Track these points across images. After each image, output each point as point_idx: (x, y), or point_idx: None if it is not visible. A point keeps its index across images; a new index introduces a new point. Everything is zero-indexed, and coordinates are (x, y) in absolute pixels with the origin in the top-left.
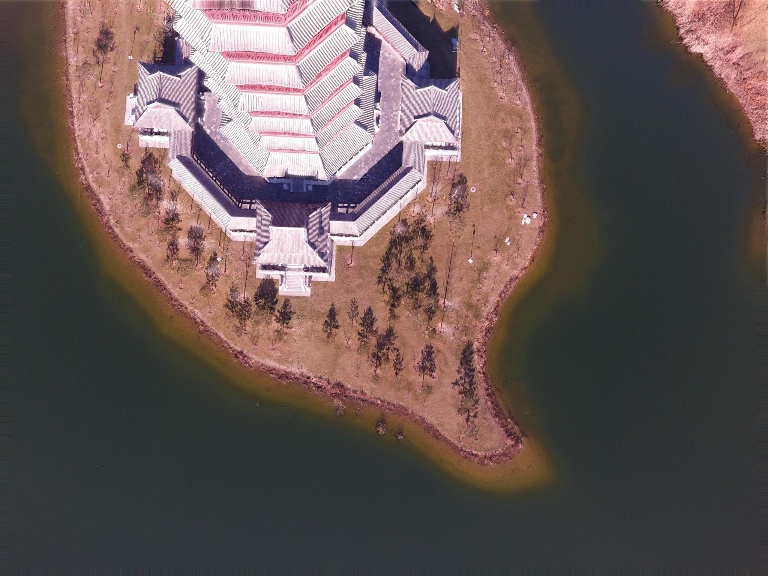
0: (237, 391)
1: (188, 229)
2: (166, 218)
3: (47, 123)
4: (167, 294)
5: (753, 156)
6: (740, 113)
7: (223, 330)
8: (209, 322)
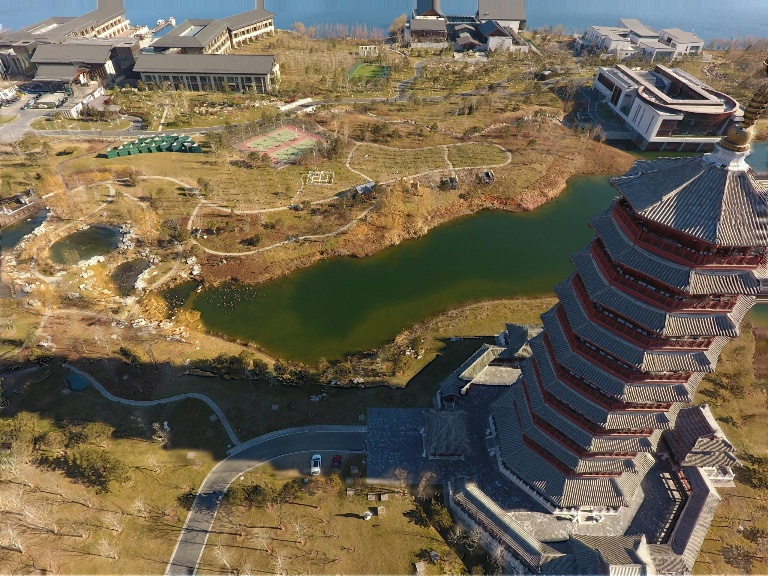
0: None
1: (730, 567)
2: None
3: None
4: None
5: (482, 215)
6: (458, 218)
7: None
8: None
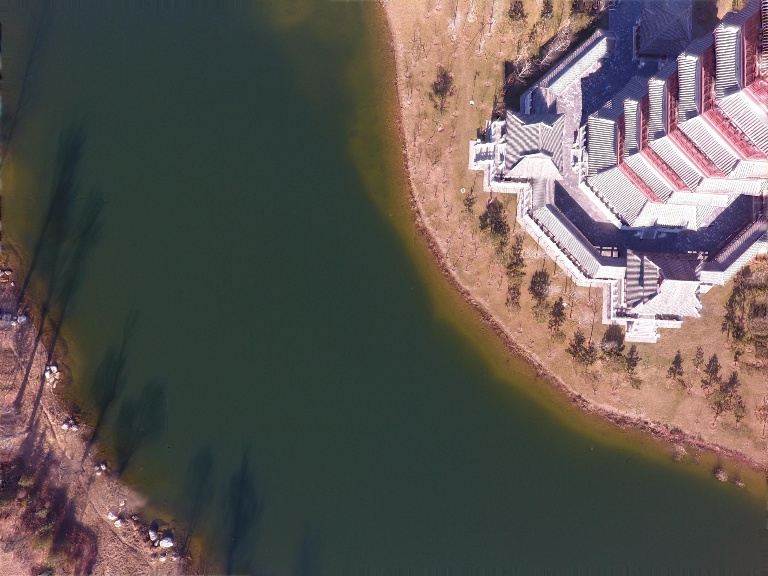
0: (572, 434)
1: (532, 274)
2: (509, 262)
3: (379, 165)
4: (505, 337)
5: None
6: None
7: (562, 374)
8: (547, 366)
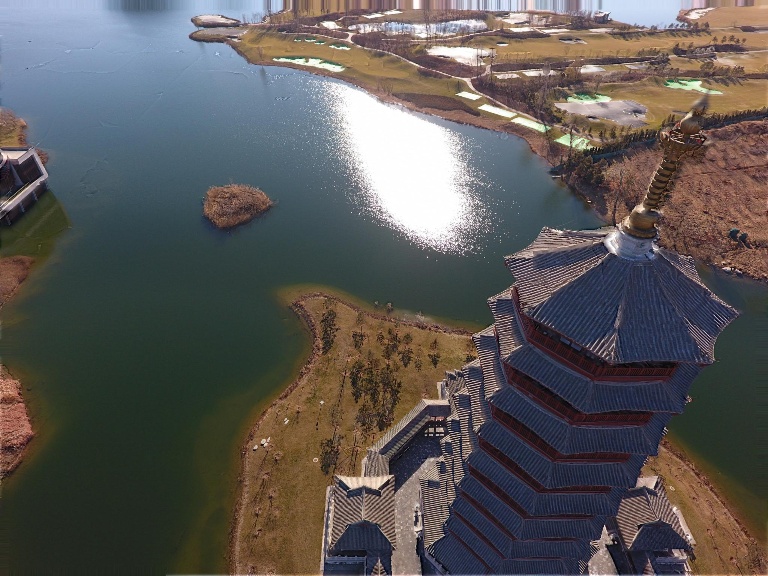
0: None
1: None
2: None
3: (766, 526)
4: None
5: None
6: None
7: None
8: None
